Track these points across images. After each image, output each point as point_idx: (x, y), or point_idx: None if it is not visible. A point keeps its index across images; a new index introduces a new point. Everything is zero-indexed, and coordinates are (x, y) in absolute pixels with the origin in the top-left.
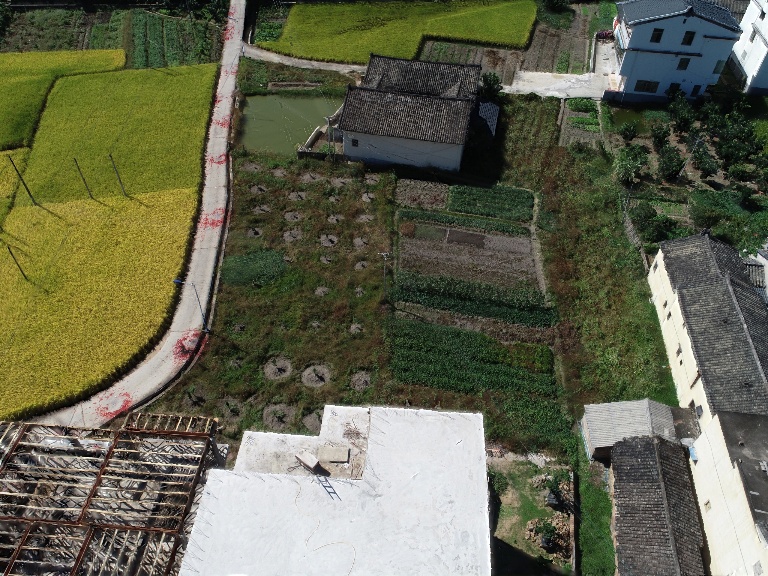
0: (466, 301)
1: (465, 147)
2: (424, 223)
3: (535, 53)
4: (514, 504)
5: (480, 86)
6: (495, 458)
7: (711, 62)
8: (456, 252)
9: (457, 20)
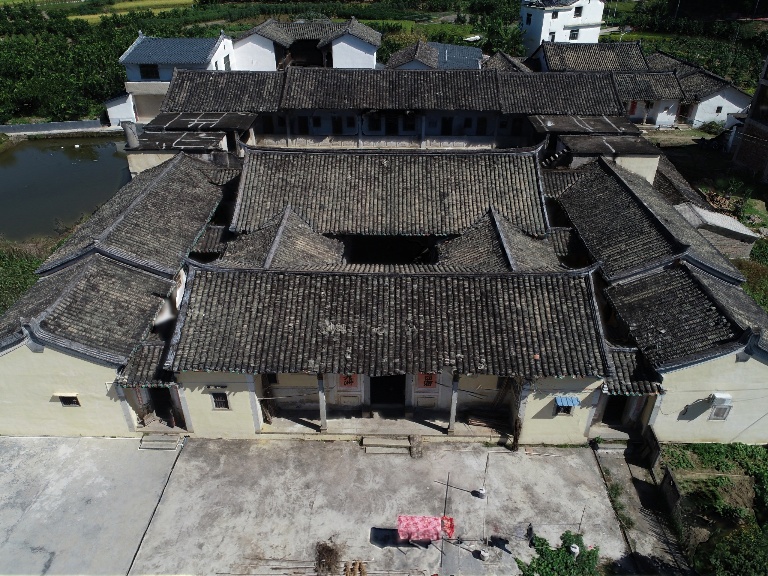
0: None
1: None
2: None
3: None
4: None
5: None
6: None
7: None
8: None
9: None
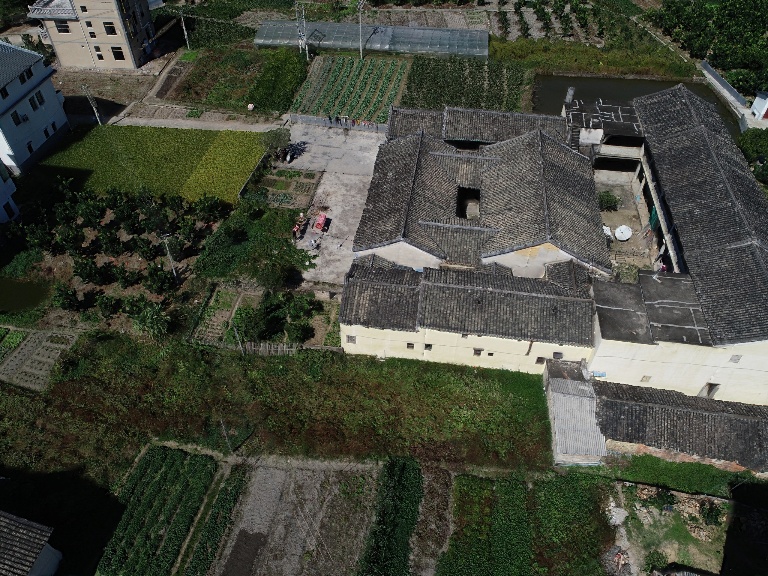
0: (386, 573)
1: None
2: None
3: None
4: (676, 548)
5: None
6: (631, 561)
7: None
8: None
9: None
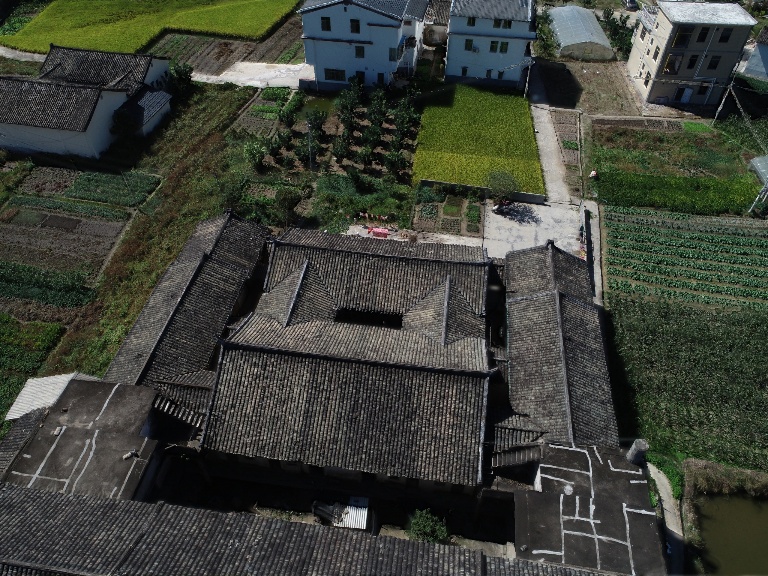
0: (11, 283)
1: (113, 135)
2: (31, 209)
3: (269, 44)
4: None
5: (159, 76)
6: None
7: (384, 50)
8: (41, 236)
9: (207, 13)
